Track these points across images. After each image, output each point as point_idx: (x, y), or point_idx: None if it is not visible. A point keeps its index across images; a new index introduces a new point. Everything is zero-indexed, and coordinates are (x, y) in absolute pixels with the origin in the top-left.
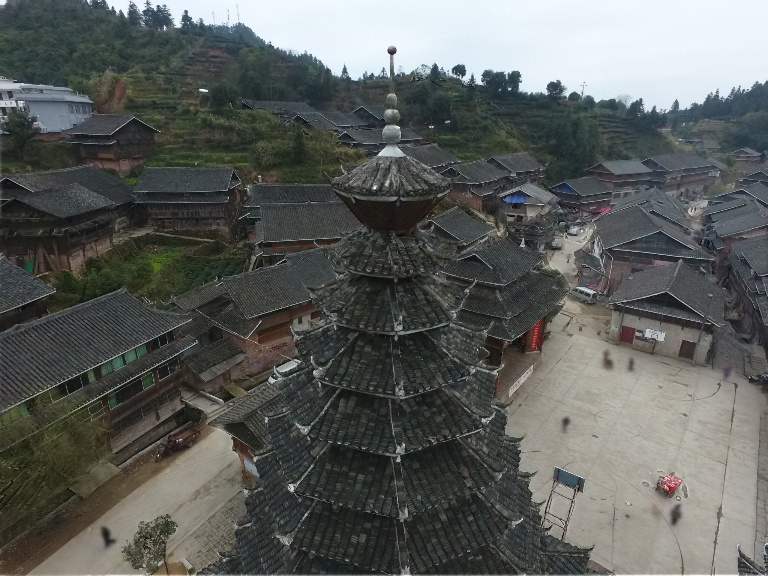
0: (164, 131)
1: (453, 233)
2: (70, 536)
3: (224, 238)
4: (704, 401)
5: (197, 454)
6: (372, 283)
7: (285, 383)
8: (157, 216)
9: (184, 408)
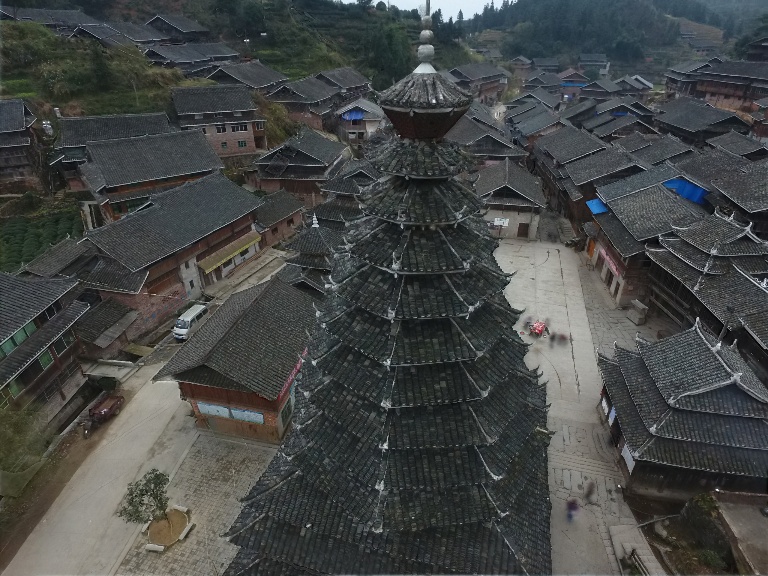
0: None
1: (313, 155)
2: (24, 534)
3: (35, 190)
4: (542, 266)
5: (130, 418)
6: (420, 186)
7: (342, 288)
8: None
9: (88, 381)
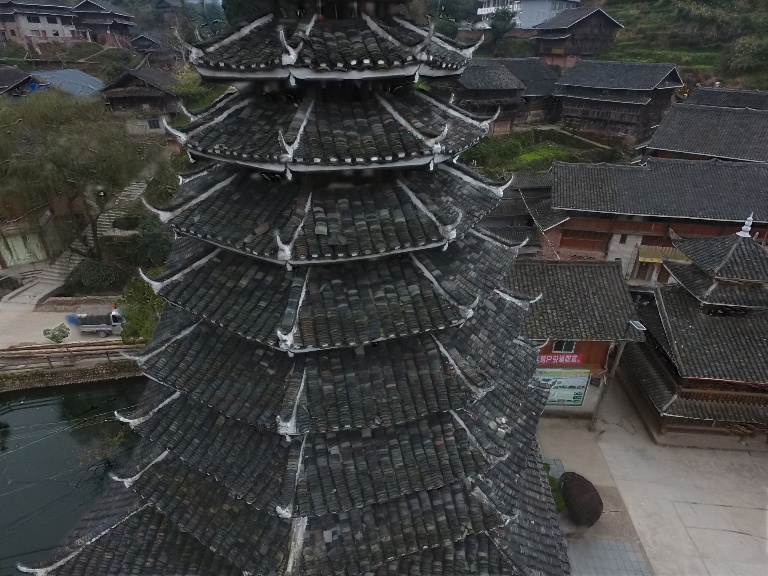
0: (630, 27)
1: None
2: None
3: (626, 149)
4: None
5: None
6: None
7: None
8: (568, 113)
9: None
